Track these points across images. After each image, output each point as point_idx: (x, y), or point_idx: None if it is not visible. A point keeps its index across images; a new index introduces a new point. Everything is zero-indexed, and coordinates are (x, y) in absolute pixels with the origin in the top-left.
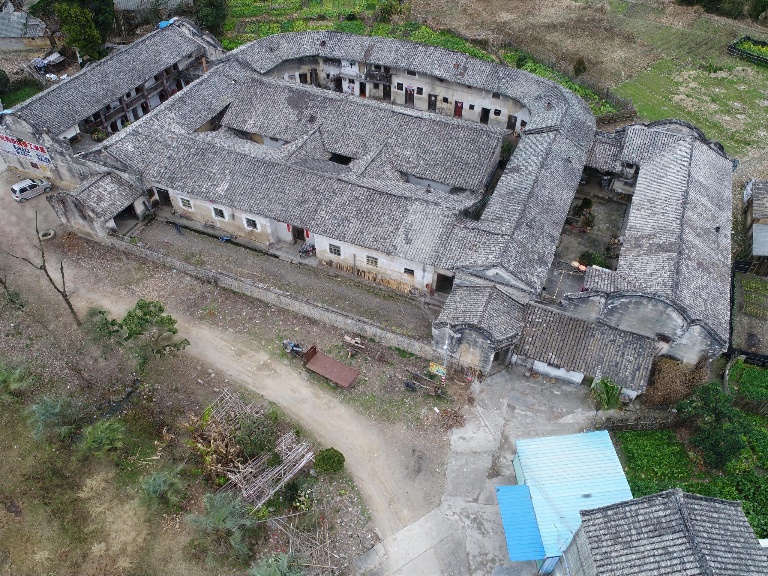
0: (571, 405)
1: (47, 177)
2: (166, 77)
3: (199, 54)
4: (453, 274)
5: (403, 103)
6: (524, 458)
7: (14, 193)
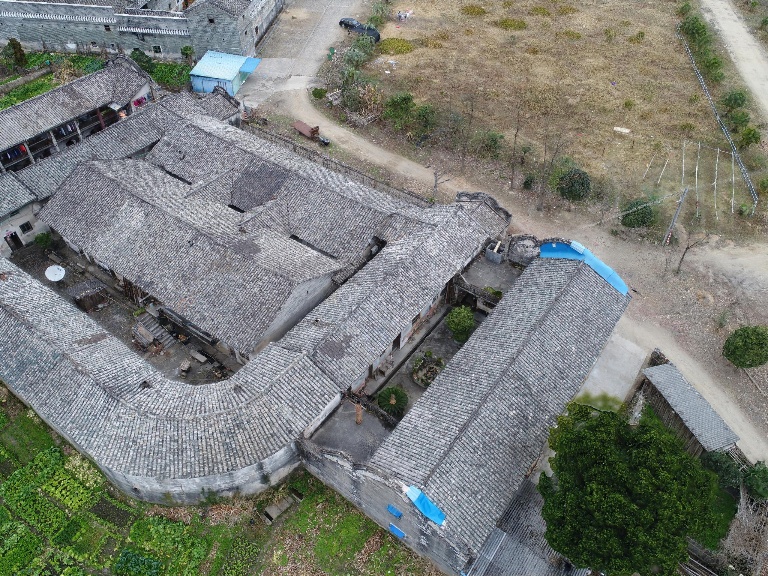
0: None
1: None
2: None
3: None
4: None
5: None
6: None
7: None
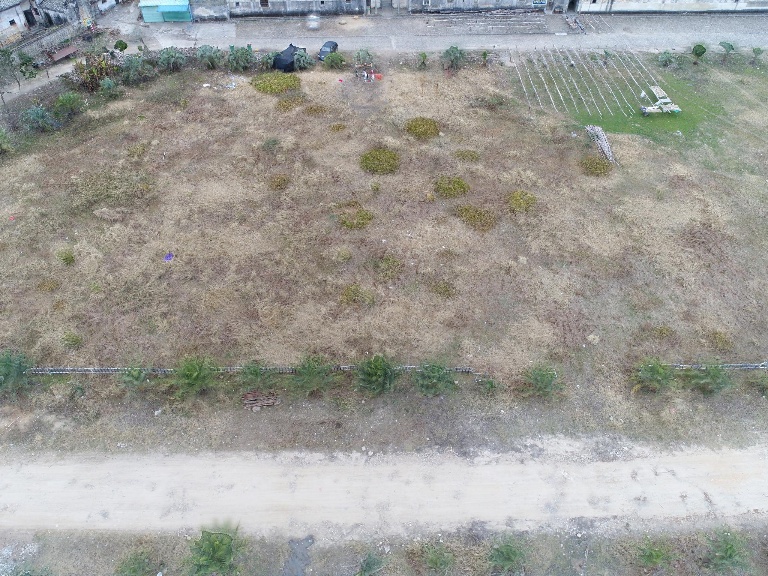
0: (125, 9)
1: None
2: None
3: None
4: (29, 5)
5: None
6: (147, 5)
7: None
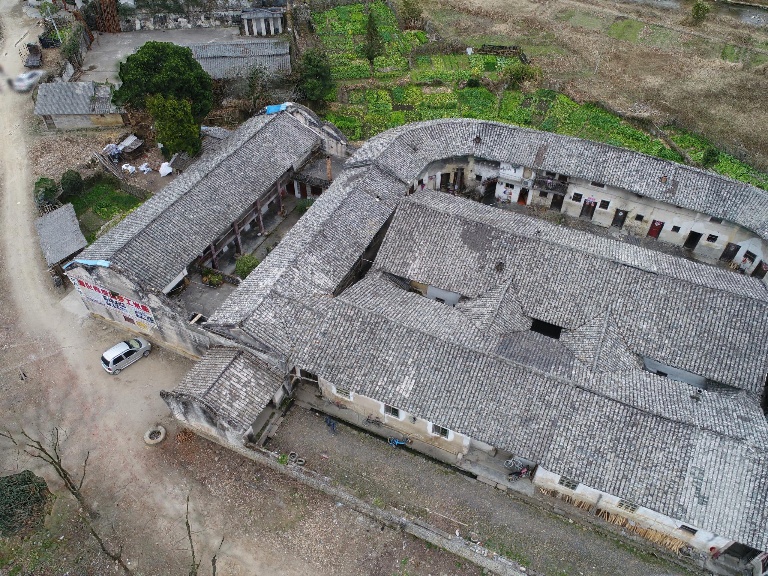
0: None
1: (144, 334)
2: (280, 182)
3: (315, 147)
4: None
5: (577, 216)
6: None
7: (106, 364)
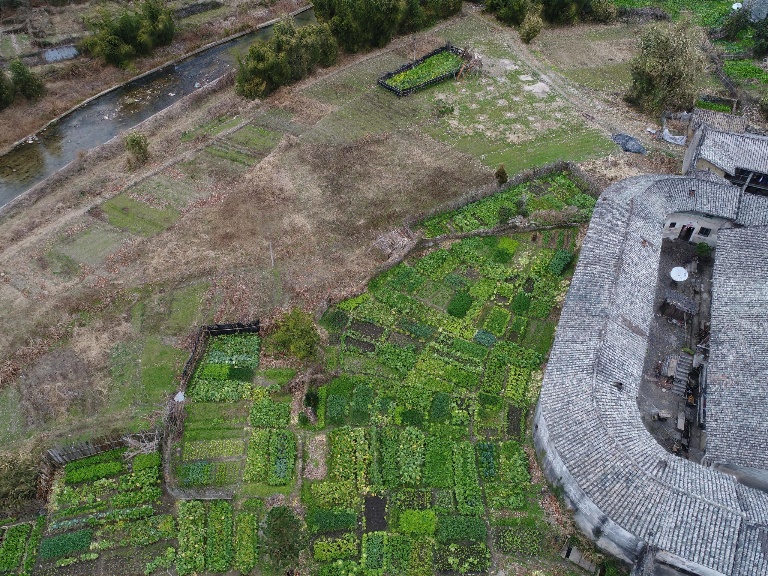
0: None
1: None
2: None
3: None
4: None
5: None
6: None
7: None
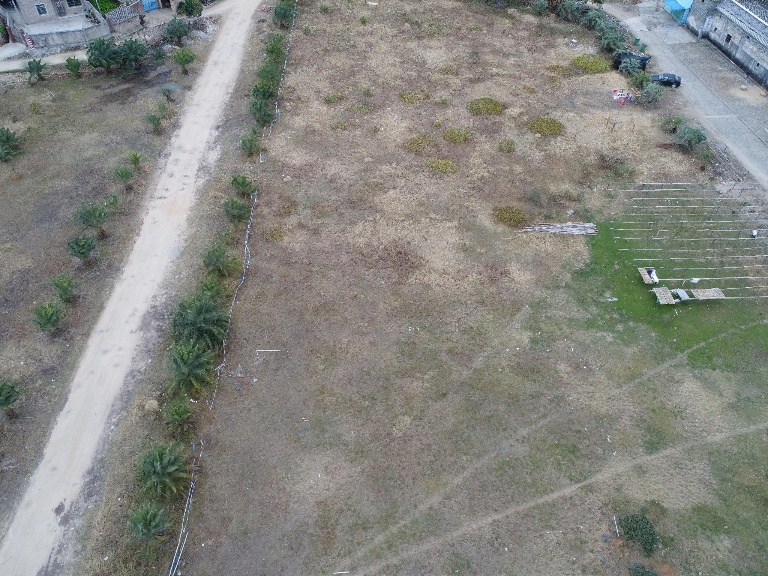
0: None
1: None
2: None
3: None
4: None
5: None
6: None
7: None
